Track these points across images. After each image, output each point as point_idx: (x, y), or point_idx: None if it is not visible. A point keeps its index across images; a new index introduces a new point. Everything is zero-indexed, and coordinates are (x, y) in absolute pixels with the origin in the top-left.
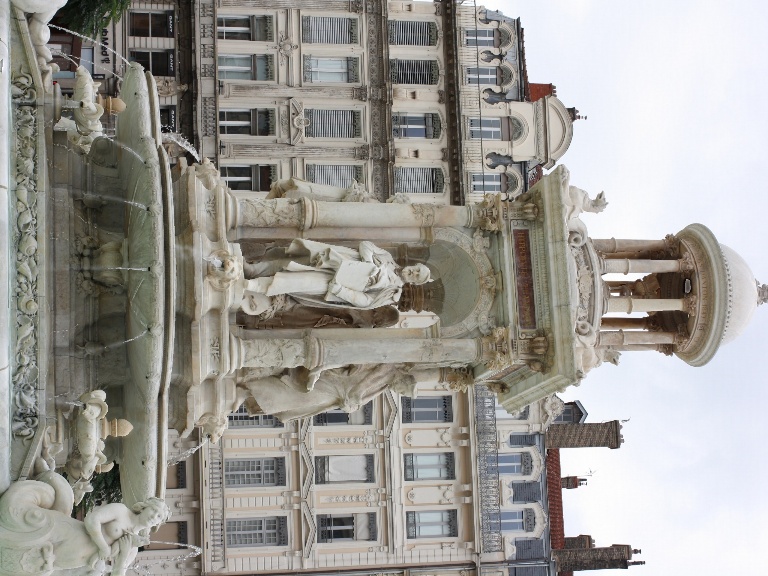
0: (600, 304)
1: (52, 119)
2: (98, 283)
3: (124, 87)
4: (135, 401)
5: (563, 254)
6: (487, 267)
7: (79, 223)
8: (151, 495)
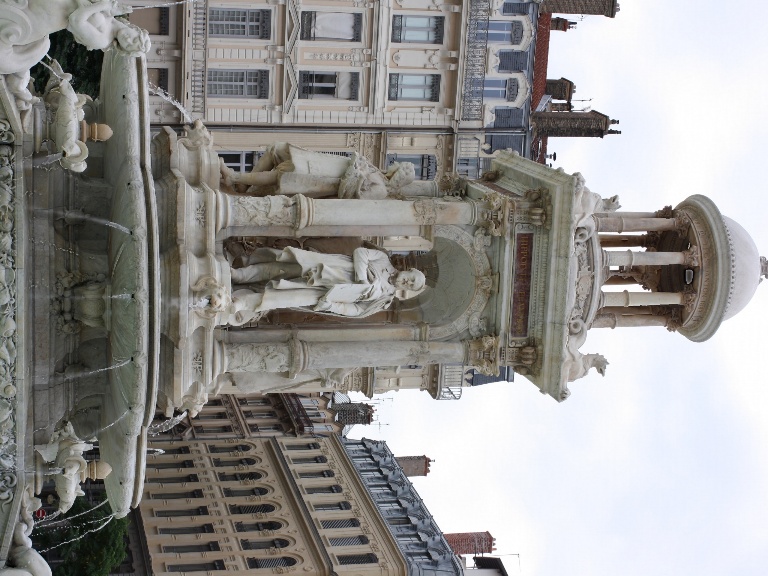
0: (596, 303)
1: (32, 153)
2: (79, 320)
3: (111, 63)
4: (115, 423)
5: (565, 271)
6: (485, 266)
7: (60, 260)
8: (128, 503)
